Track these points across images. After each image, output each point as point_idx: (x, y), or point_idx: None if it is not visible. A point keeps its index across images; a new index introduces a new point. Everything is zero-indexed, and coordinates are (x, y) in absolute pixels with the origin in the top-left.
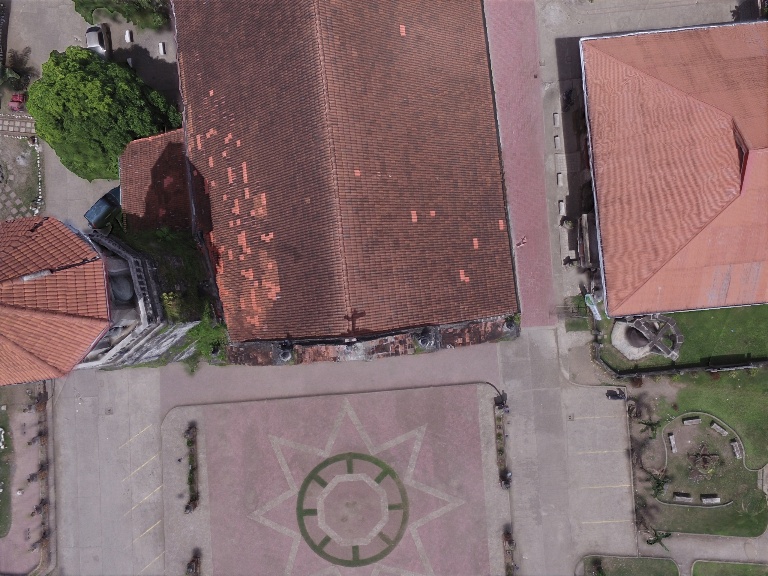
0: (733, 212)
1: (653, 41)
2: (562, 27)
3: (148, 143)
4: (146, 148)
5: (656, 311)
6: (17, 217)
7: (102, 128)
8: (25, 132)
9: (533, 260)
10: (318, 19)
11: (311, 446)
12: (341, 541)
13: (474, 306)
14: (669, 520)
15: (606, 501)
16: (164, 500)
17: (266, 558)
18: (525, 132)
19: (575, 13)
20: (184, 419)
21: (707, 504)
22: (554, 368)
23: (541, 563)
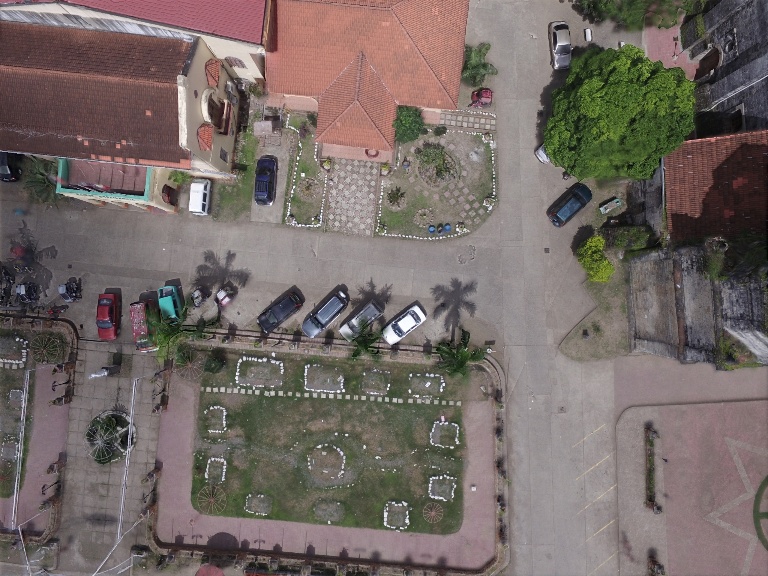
0: None
1: None
2: None
3: (709, 144)
4: (706, 149)
5: None
6: (470, 213)
7: None
8: (479, 128)
9: None
10: None
11: None
12: None
13: None
14: None
15: None
16: (619, 500)
17: (722, 560)
18: None
19: None
20: (640, 419)
21: None
22: None
23: None
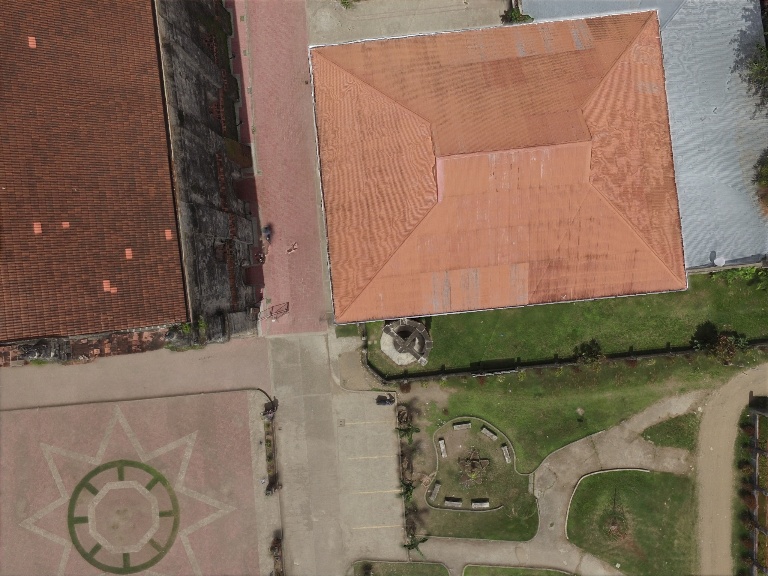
0: (435, 219)
1: (378, 48)
2: (333, 33)
3: None
4: None
5: (382, 317)
6: None
7: None
8: None
9: (304, 266)
10: None
11: (82, 454)
12: (112, 548)
13: (122, 316)
14: (440, 525)
15: (377, 506)
16: None
17: (37, 566)
18: (296, 138)
19: (345, 19)
20: None
21: (478, 508)
22: (325, 374)
23: (312, 569)
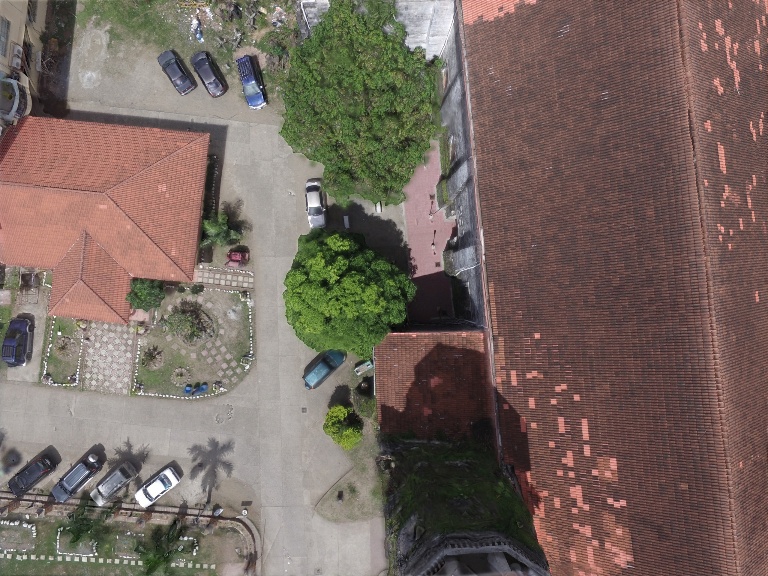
0: None
1: None
2: None
3: (411, 338)
4: (409, 343)
5: None
6: (227, 372)
7: (369, 325)
8: (237, 286)
9: None
10: (715, 315)
11: None
12: None
13: None
14: None
15: None
16: None
17: None
18: None
19: None
20: None
21: None
22: None
23: None
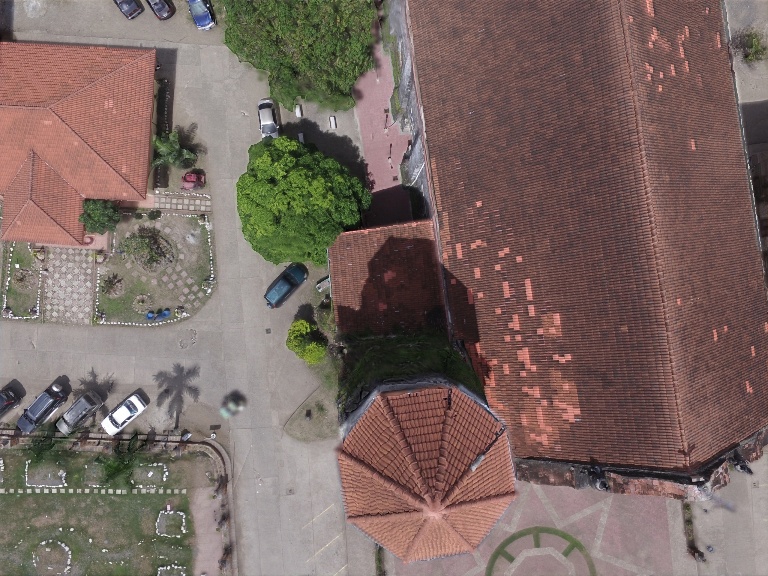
0: None
1: None
2: None
3: (364, 235)
4: (361, 240)
5: None
6: (189, 297)
7: (319, 223)
8: (194, 210)
9: None
10: (645, 149)
11: None
12: None
13: (757, 416)
14: None
15: None
16: None
17: None
18: None
19: (749, 78)
20: None
21: None
22: None
23: None
